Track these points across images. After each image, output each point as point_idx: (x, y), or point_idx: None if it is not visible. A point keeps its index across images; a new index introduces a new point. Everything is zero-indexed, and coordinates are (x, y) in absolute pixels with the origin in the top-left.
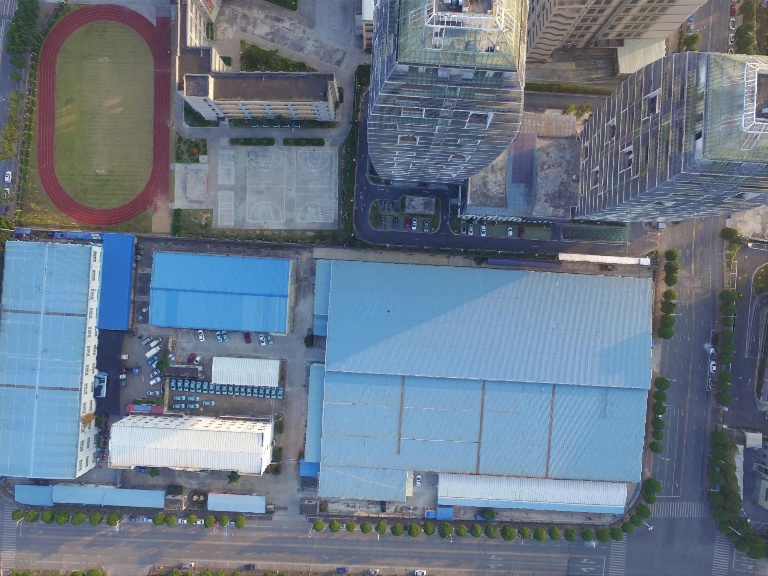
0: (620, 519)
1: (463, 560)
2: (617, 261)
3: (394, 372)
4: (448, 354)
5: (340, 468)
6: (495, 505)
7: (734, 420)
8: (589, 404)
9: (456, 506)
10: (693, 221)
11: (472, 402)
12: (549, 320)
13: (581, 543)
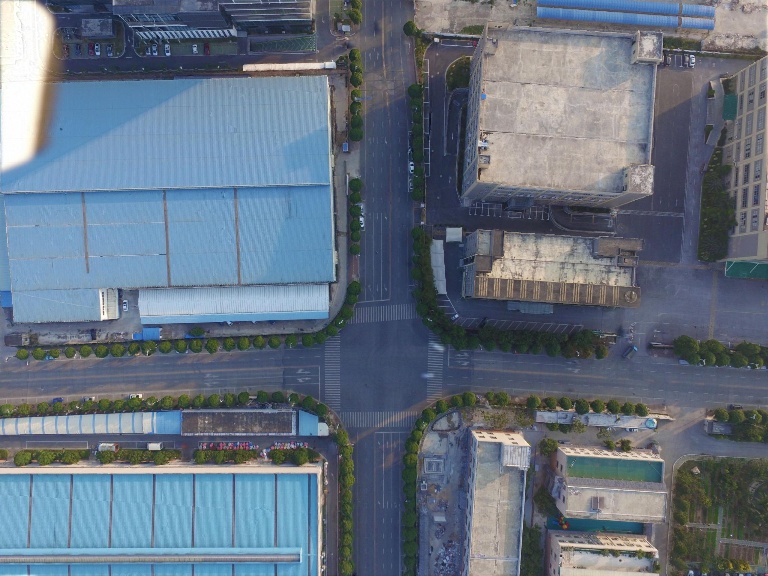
0: (328, 325)
1: (178, 381)
2: (302, 67)
3: (69, 188)
4: (123, 166)
5: (31, 292)
6: (198, 320)
7: (437, 219)
8: (273, 206)
9: (166, 328)
10: (381, 23)
11: (155, 214)
12: (224, 125)
13: (294, 354)
